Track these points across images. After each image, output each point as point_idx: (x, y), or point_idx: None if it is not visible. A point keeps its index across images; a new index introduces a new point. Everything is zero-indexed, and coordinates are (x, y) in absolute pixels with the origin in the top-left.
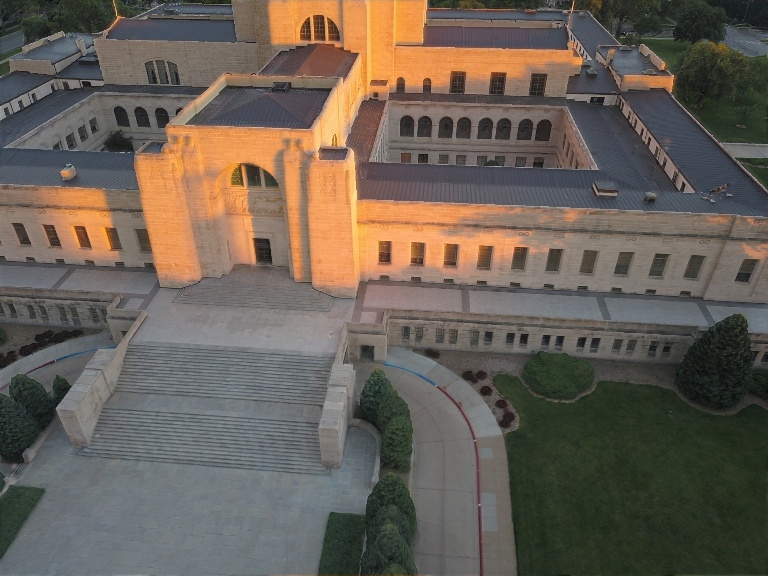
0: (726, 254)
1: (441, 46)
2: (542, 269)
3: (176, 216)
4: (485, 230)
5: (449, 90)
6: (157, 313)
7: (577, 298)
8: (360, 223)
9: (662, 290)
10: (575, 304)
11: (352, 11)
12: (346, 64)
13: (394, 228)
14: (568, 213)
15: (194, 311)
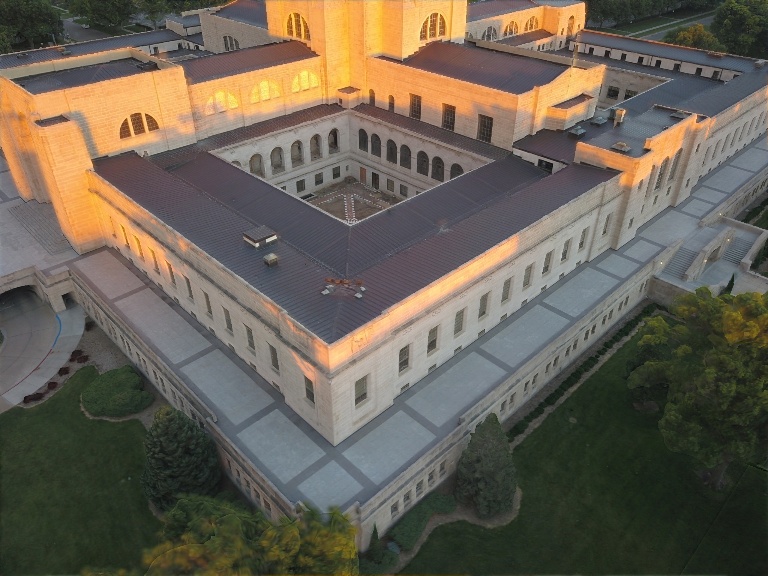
0: (283, 355)
1: (420, 65)
2: (185, 293)
3: (6, 143)
4: (144, 232)
5: (409, 113)
6: None
7: (198, 336)
8: (89, 191)
9: (259, 369)
10: (186, 340)
11: (314, 13)
12: (285, 62)
13: (108, 205)
14: (179, 241)
15: (4, 219)
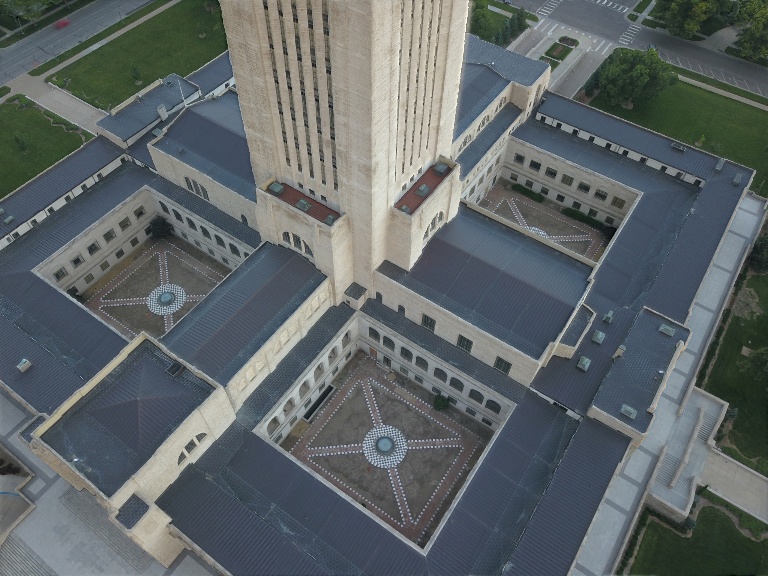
0: None
1: (428, 279)
2: None
3: None
4: None
5: (421, 323)
6: (43, 507)
7: None
8: (171, 535)
9: None
10: None
11: (320, 249)
12: (297, 300)
13: None
14: None
15: (64, 518)
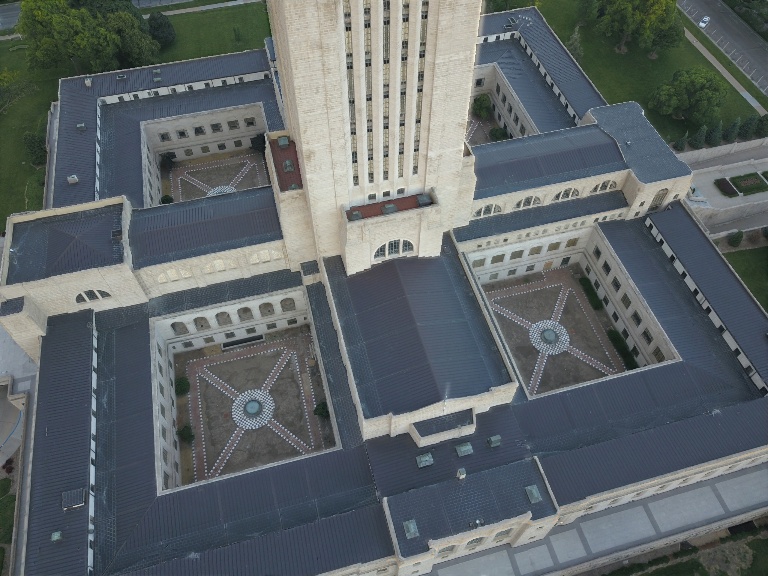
0: None
1: (357, 292)
2: None
3: None
4: None
5: None
6: None
7: None
8: None
9: None
10: None
11: None
12: (245, 242)
13: None
14: None
15: None
